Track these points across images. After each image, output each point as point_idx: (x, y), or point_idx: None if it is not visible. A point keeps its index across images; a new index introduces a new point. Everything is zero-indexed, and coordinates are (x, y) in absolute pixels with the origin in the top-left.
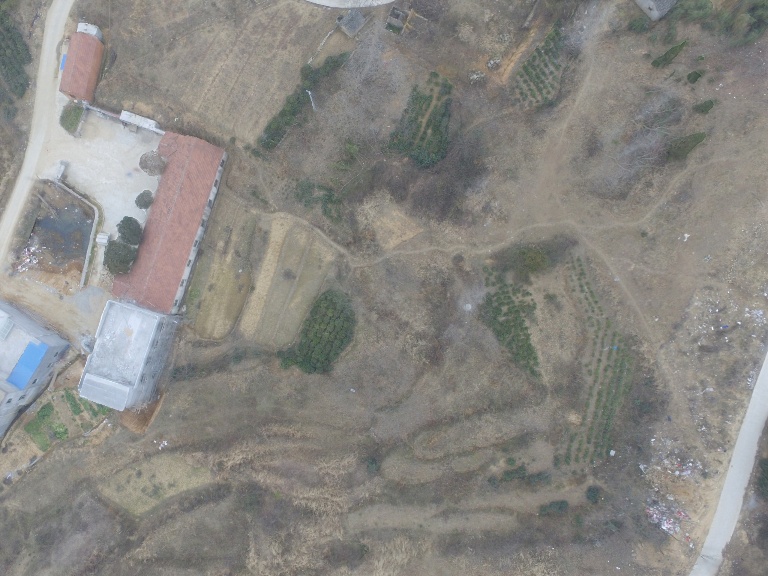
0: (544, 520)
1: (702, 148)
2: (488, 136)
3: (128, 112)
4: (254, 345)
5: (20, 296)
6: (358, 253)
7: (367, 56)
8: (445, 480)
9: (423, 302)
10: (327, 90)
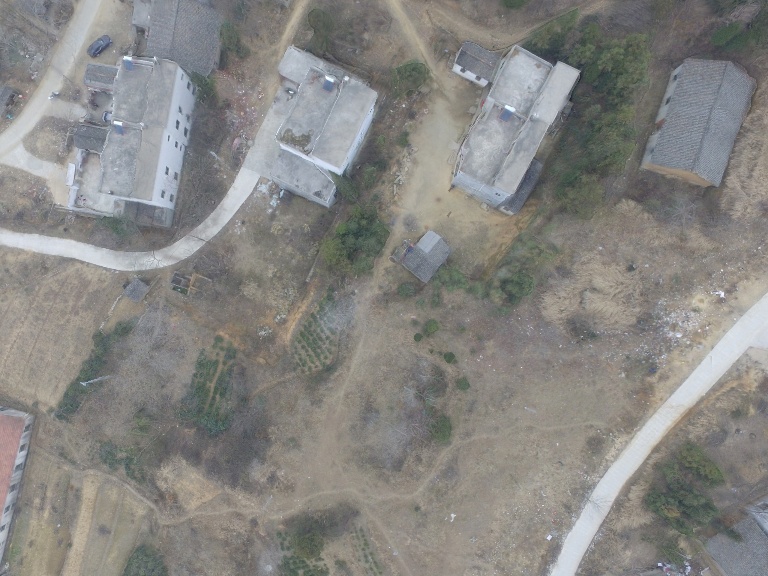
0: None
1: (465, 424)
2: (272, 402)
3: None
4: None
5: None
6: (165, 511)
7: (155, 320)
8: None
9: (228, 560)
10: (119, 355)
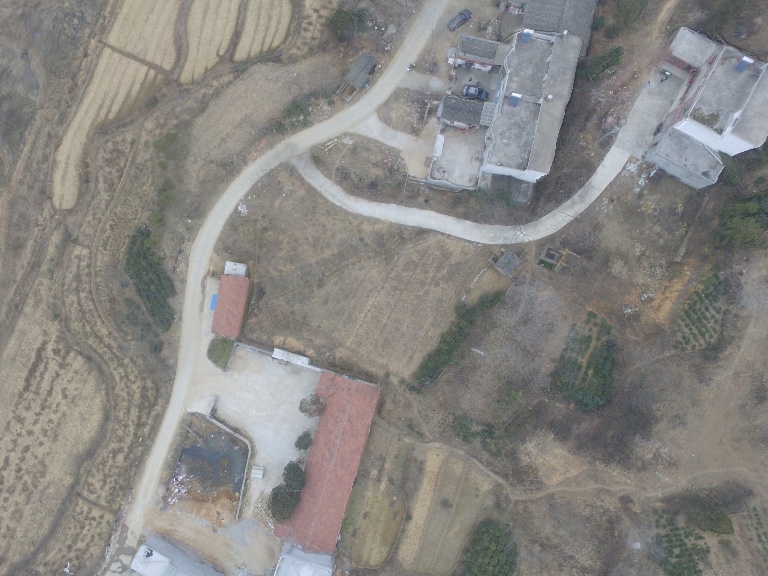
0: None
1: None
2: (652, 379)
3: (280, 350)
4: (413, 574)
5: (172, 530)
6: (519, 486)
7: (522, 294)
8: None
9: (588, 537)
10: (483, 328)
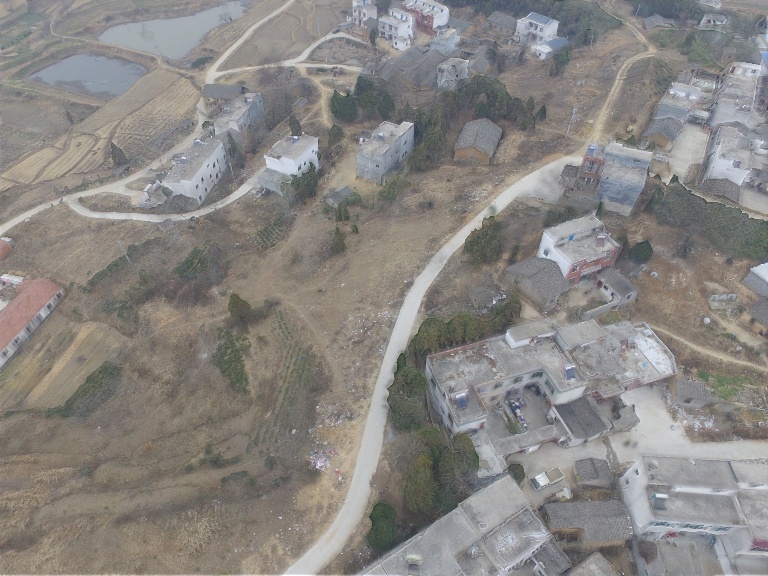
0: (223, 489)
1: (355, 247)
2: (234, 262)
3: (8, 274)
4: None
5: None
6: (136, 336)
7: (172, 238)
8: (148, 475)
9: (174, 359)
10: (142, 254)
